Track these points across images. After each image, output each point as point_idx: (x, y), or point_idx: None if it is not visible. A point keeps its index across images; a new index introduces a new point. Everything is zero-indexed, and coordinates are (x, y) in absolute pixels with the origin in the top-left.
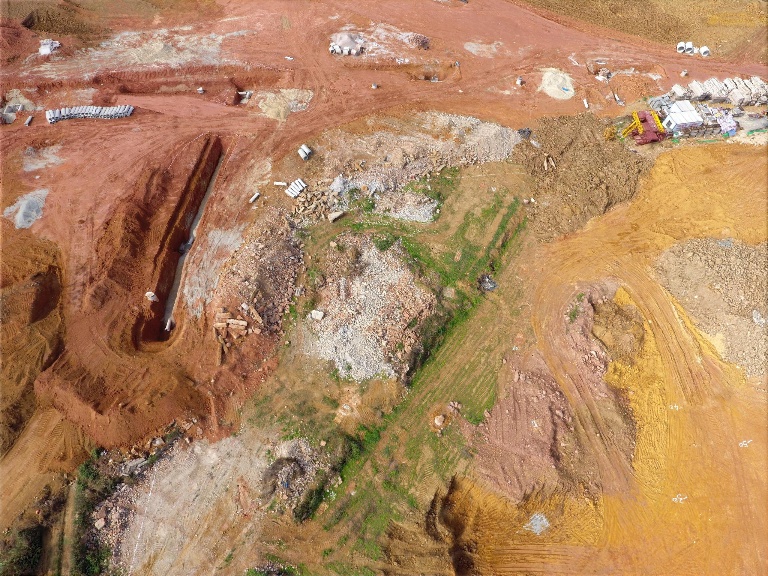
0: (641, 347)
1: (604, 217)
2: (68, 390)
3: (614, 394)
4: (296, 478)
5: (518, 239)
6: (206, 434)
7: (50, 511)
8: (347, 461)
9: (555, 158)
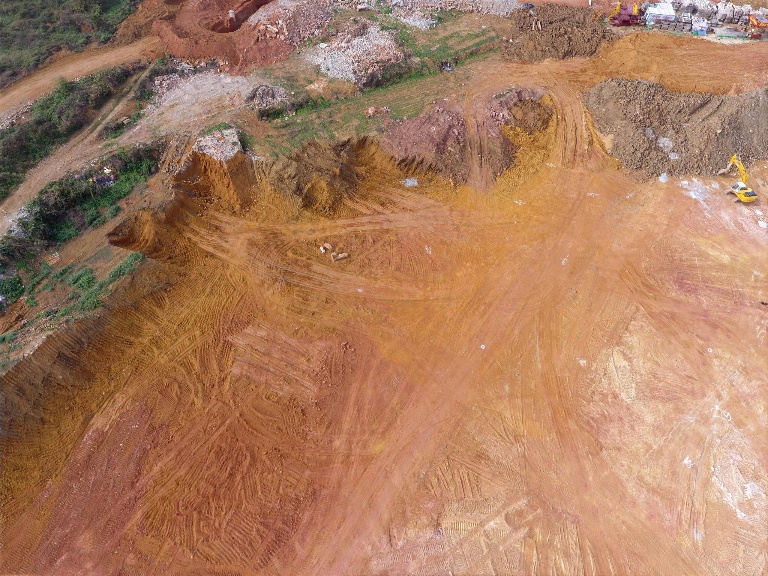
0: (544, 128)
1: (562, 61)
2: (168, 27)
3: (504, 138)
4: (268, 97)
5: (486, 55)
6: (230, 72)
7: (137, 68)
8: (303, 108)
9: (543, 23)
